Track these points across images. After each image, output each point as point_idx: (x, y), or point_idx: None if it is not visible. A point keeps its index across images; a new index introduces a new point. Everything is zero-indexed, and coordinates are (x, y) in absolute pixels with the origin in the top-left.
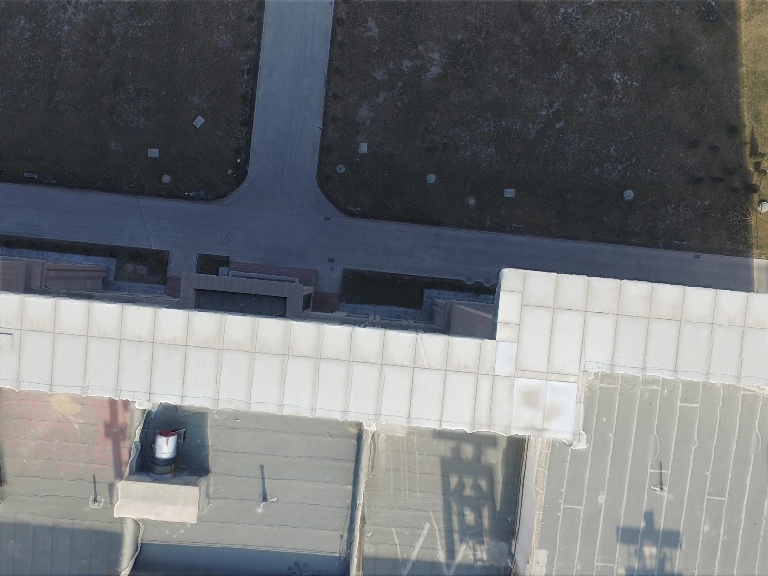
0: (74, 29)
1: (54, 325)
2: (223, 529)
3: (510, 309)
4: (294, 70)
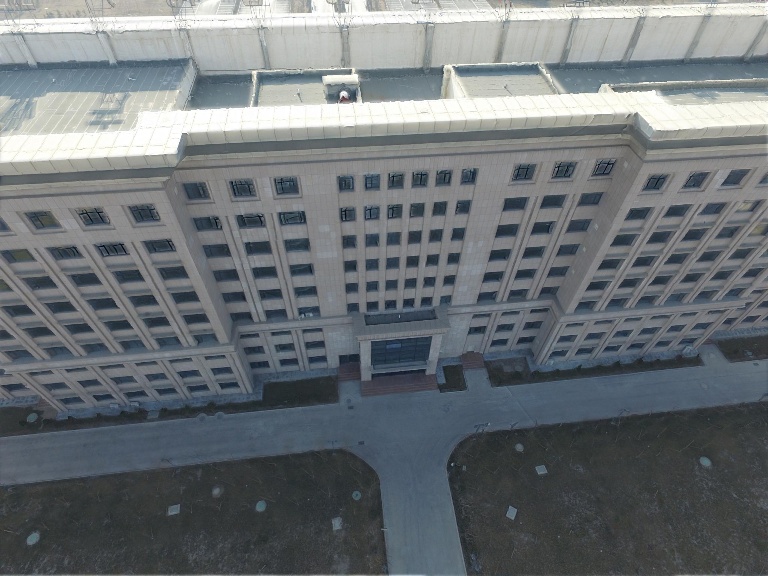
0: None
1: (403, 116)
2: (317, 87)
3: (173, 143)
4: None
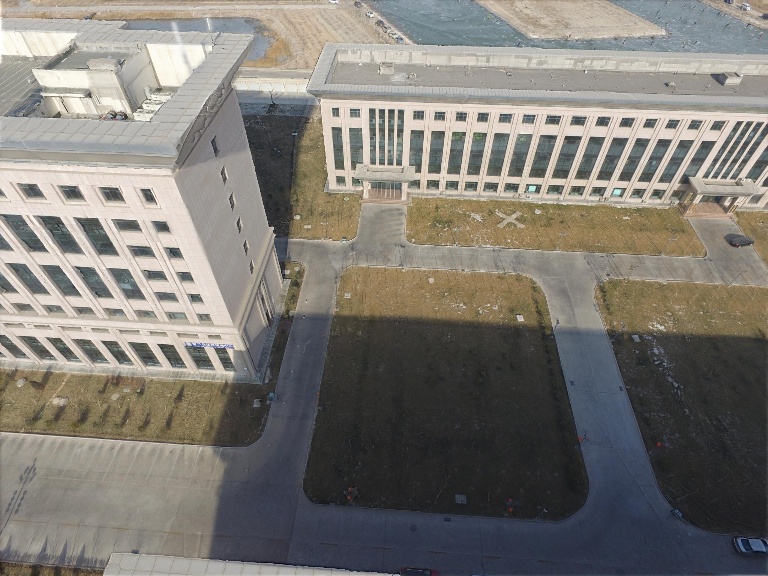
0: None
1: None
2: None
3: None
4: None
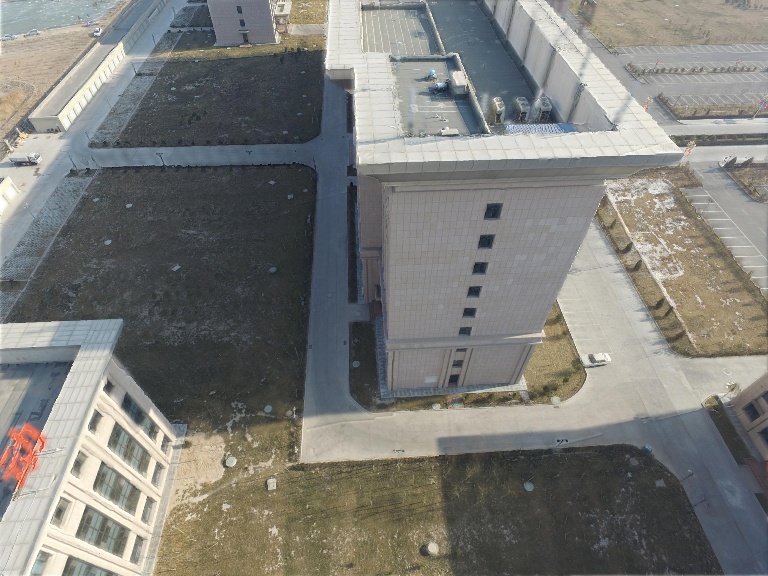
0: (213, 235)
1: None
2: None
3: None
4: (244, 155)
